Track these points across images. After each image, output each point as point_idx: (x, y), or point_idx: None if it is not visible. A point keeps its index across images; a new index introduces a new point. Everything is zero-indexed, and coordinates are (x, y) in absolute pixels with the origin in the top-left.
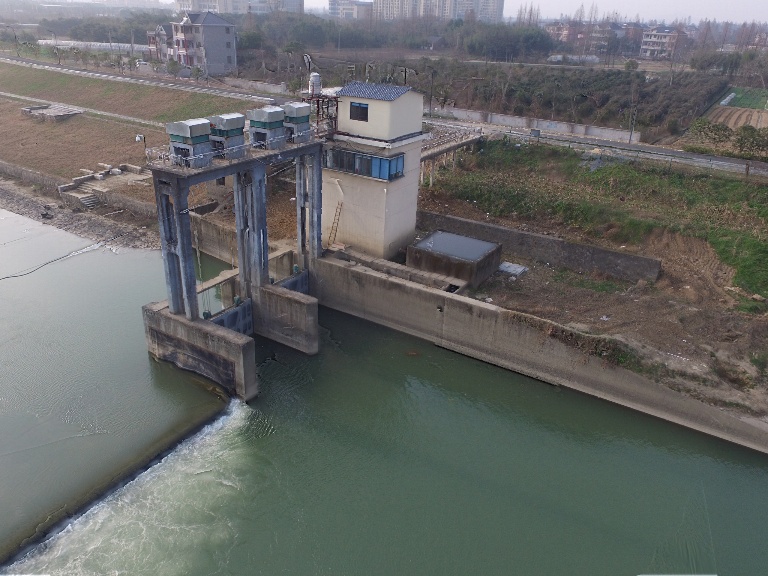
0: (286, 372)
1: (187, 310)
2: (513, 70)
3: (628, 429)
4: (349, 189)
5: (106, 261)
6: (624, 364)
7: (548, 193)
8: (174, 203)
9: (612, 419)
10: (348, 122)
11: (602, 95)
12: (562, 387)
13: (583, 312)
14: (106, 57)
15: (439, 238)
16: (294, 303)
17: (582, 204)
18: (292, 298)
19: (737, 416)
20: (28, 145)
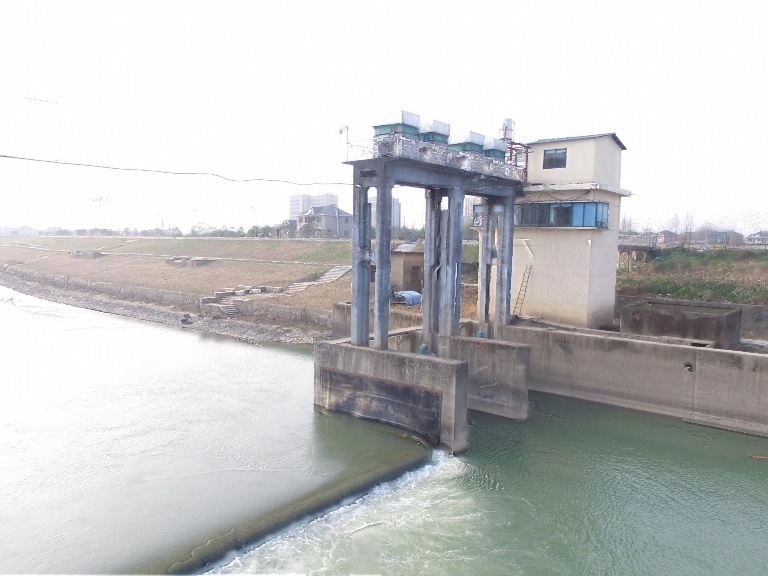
0: (493, 434)
1: (376, 335)
2: (651, 220)
3: None
4: (540, 248)
5: (248, 352)
6: None
7: (764, 282)
8: None
9: None
10: (540, 172)
11: (767, 228)
12: None
13: None
14: (241, 231)
15: None
16: (498, 349)
17: None
18: (495, 343)
19: None
20: (170, 279)
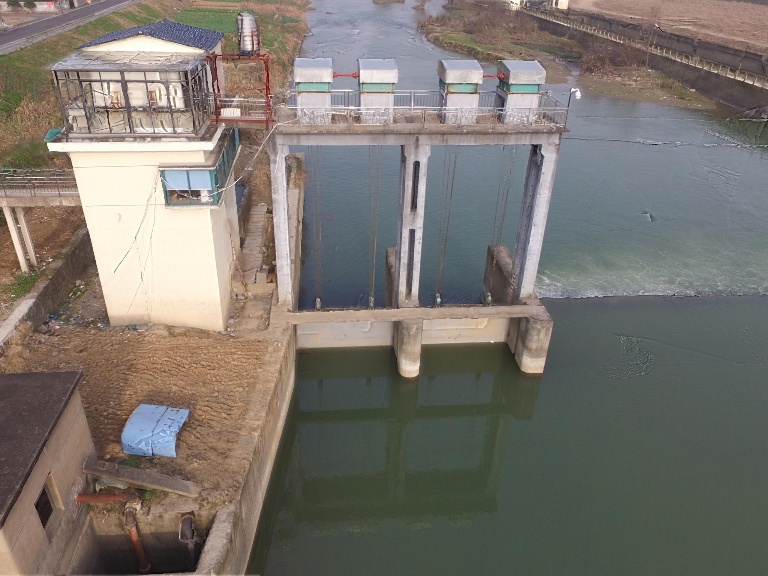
0: None
1: None
2: None
3: None
4: None
5: None
6: None
7: None
8: None
9: None
10: None
11: None
12: None
13: None
14: None
15: None
16: None
17: (13, 156)
18: None
19: None
20: None
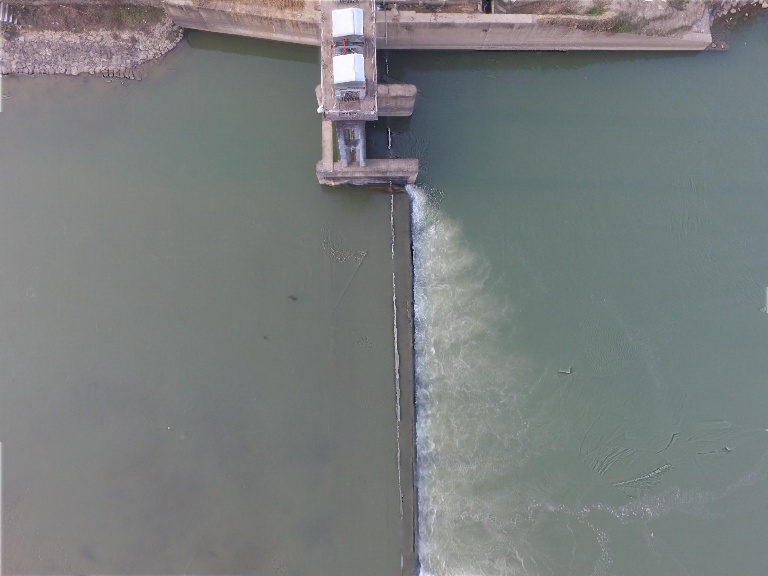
0: (410, 142)
1: (362, 164)
2: None
3: (609, 60)
4: None
5: None
6: (621, 30)
7: None
8: (359, 131)
9: (601, 59)
10: None
11: None
12: (571, 51)
13: None
14: None
15: None
16: (400, 98)
17: None
18: (398, 96)
19: (681, 37)
20: None
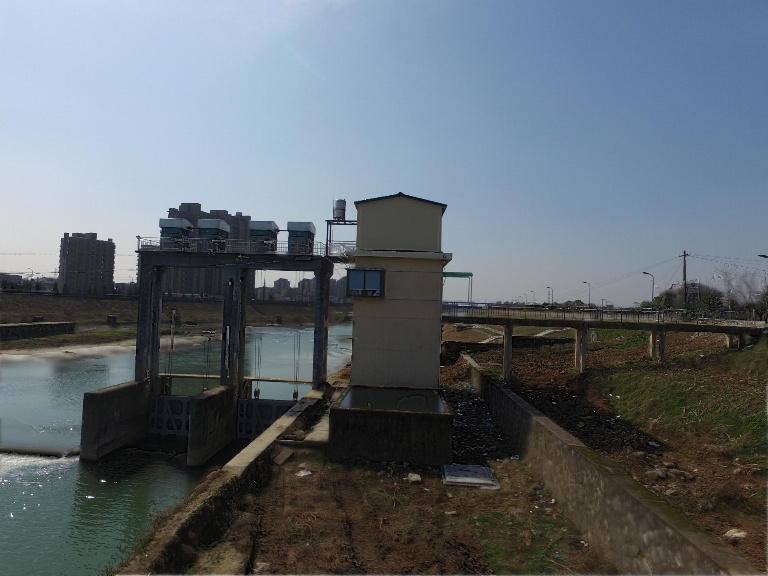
0: (148, 463)
1: None
2: None
3: None
4: None
5: None
6: None
7: (759, 397)
8: None
9: None
10: None
11: None
12: None
13: (326, 568)
14: None
15: (430, 401)
16: None
17: None
18: None
19: None
20: None
